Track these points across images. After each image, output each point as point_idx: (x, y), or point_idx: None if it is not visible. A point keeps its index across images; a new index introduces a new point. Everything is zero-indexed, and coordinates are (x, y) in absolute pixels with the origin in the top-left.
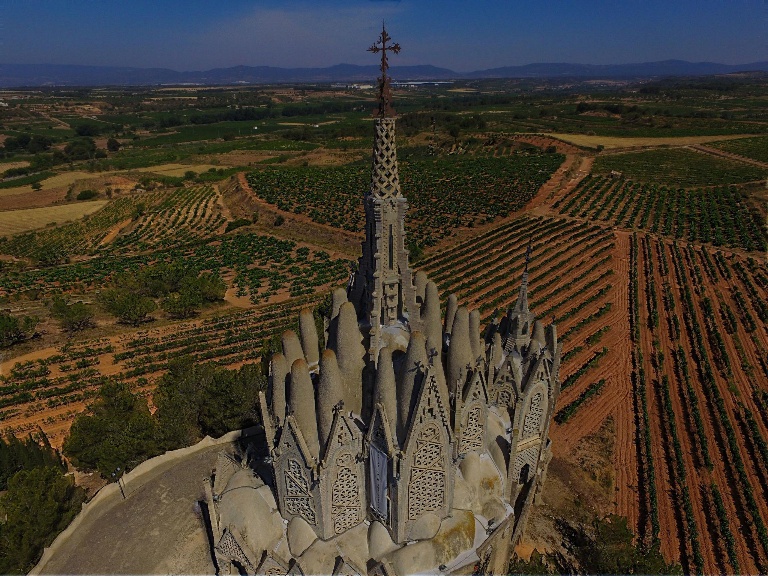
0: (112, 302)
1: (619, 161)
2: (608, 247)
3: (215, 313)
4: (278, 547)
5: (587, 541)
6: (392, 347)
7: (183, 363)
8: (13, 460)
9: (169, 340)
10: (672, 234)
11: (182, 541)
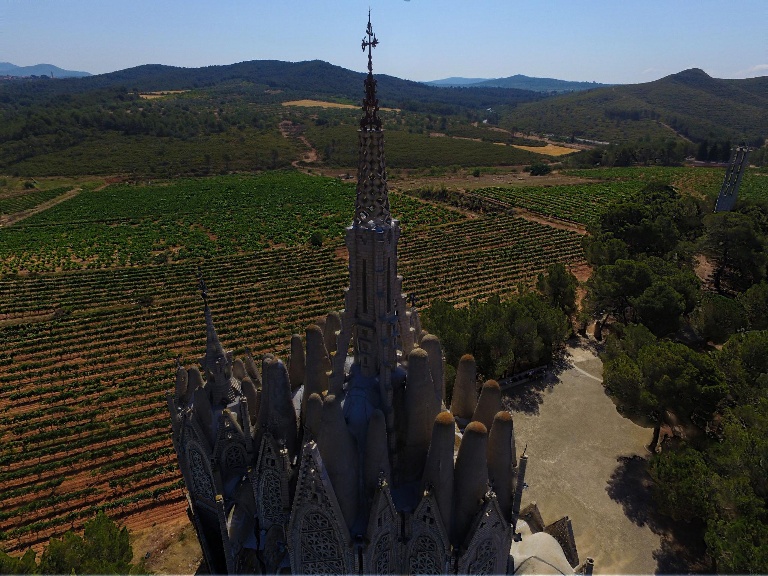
0: None
1: None
2: None
3: None
4: (521, 525)
5: None
6: None
7: None
8: None
9: None
10: None
11: None
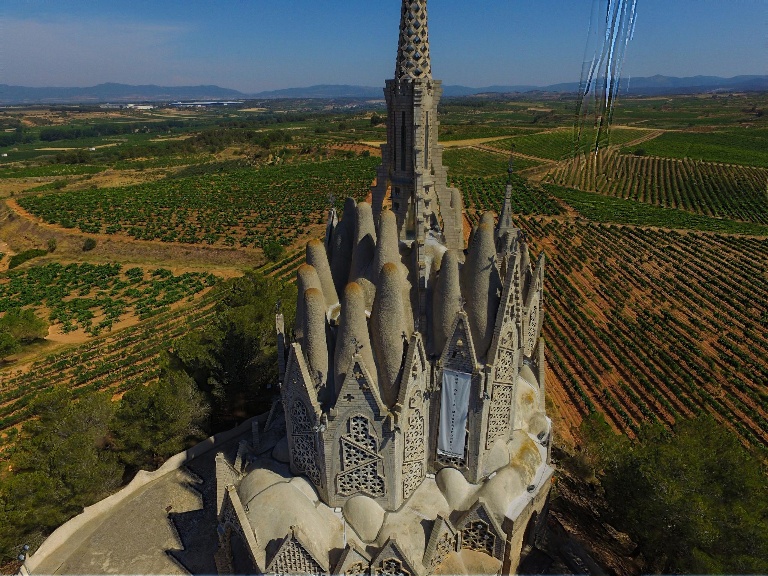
0: None
1: None
2: None
3: (41, 355)
4: (346, 539)
5: (564, 453)
6: (441, 257)
7: (56, 398)
8: None
9: None
10: (492, 210)
11: None
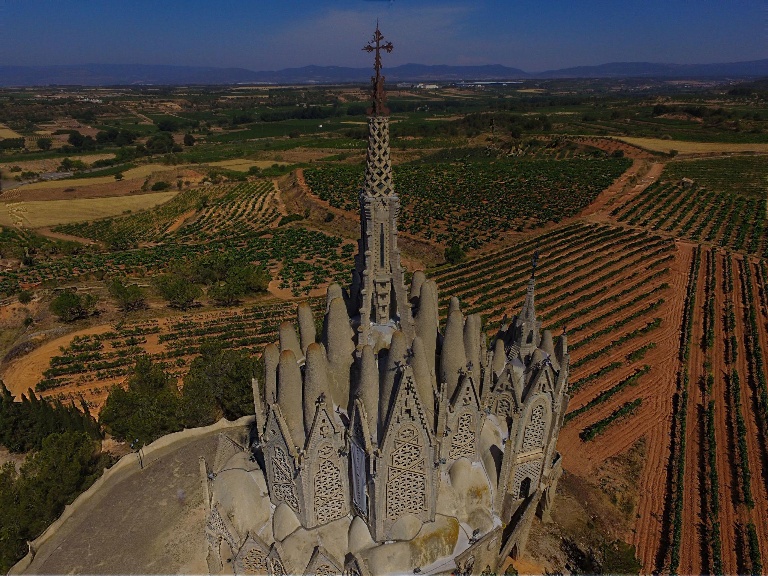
0: (163, 286)
1: (693, 168)
2: (666, 259)
3: (257, 303)
4: (262, 530)
5: None
6: (379, 345)
7: (212, 347)
8: (58, 423)
9: (210, 325)
10: (744, 248)
11: (186, 514)
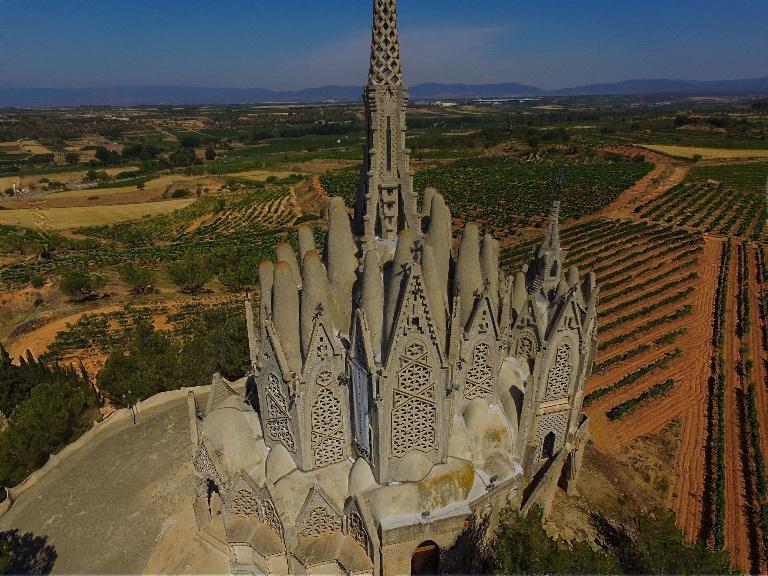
0: (173, 269)
1: (719, 171)
2: (694, 251)
3: None
4: (254, 471)
5: None
6: (385, 258)
7: (216, 314)
8: None
9: None
10: None
11: (177, 467)
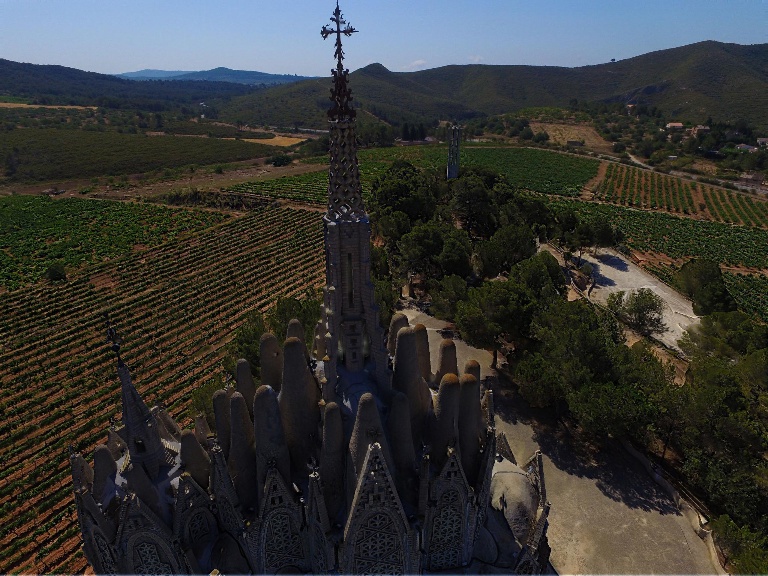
0: None
1: None
2: None
3: None
4: None
5: None
6: None
7: None
8: None
9: None
10: None
11: (585, 575)
